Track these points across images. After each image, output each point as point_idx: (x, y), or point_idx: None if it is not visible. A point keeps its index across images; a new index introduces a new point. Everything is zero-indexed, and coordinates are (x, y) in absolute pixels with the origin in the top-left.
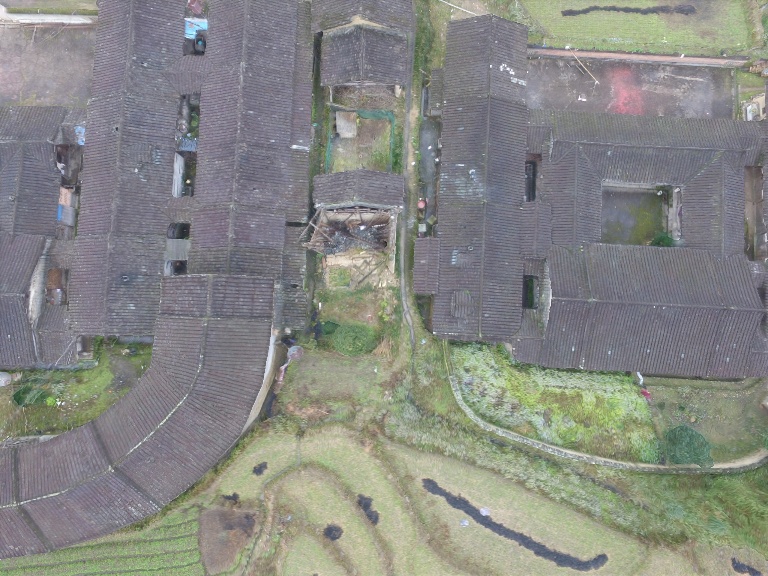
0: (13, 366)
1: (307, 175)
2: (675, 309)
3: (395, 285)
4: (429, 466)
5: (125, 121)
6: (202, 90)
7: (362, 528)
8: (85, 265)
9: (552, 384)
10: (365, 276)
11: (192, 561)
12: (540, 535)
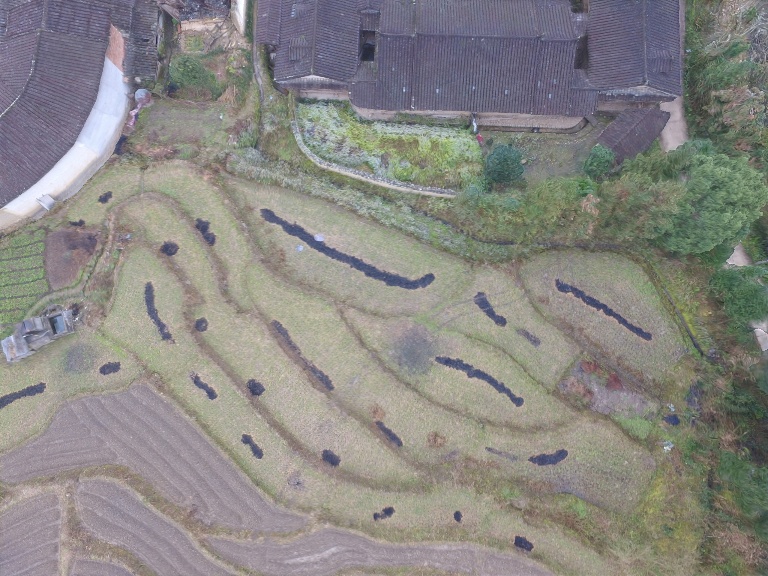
0: None
1: None
2: (493, 41)
3: (245, 47)
4: (267, 198)
5: None
6: None
7: (196, 244)
8: None
9: (390, 131)
10: (216, 38)
11: (37, 277)
12: (370, 257)
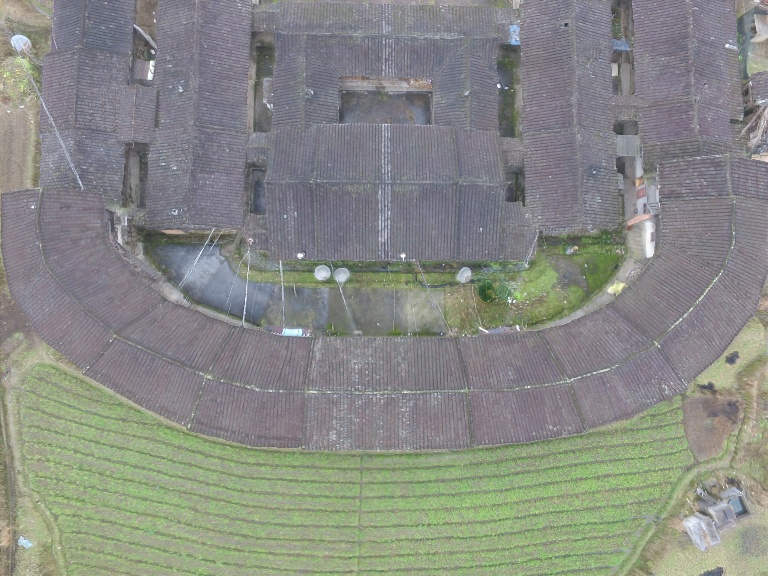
0: (444, 269)
1: (739, 74)
2: None
3: None
4: None
5: (576, 16)
6: None
7: None
8: (545, 160)
9: None
10: None
11: (681, 448)
12: None
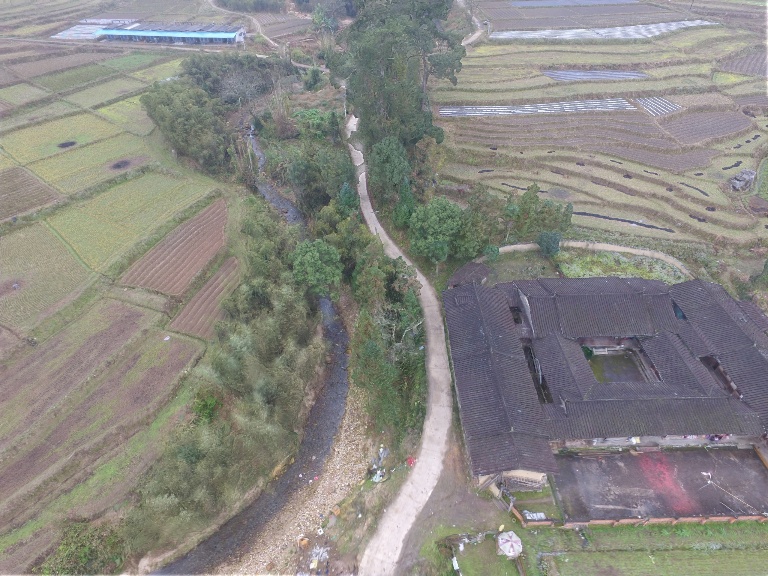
0: None
1: None
2: None
3: None
4: None
5: None
6: None
7: None
8: None
9: (624, 276)
10: None
11: None
12: (601, 220)
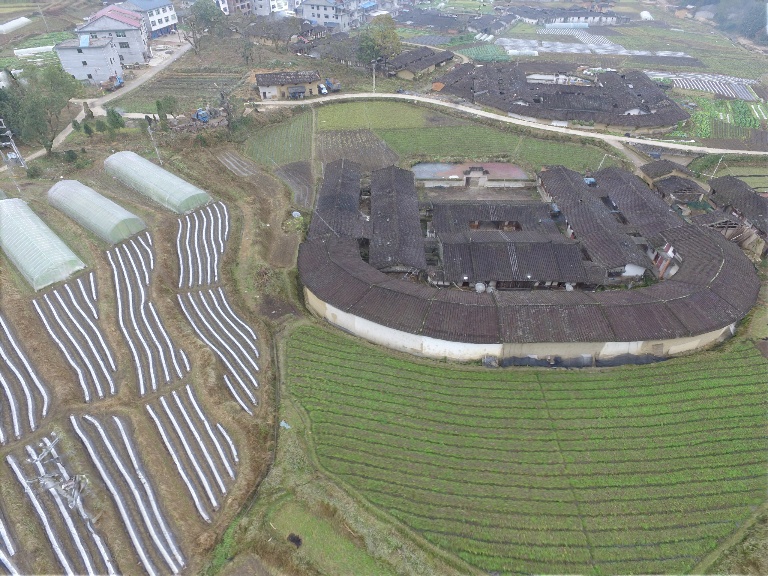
0: None
1: None
2: None
3: None
4: None
5: None
6: (609, 194)
7: None
8: None
9: None
10: None
11: None
12: None
